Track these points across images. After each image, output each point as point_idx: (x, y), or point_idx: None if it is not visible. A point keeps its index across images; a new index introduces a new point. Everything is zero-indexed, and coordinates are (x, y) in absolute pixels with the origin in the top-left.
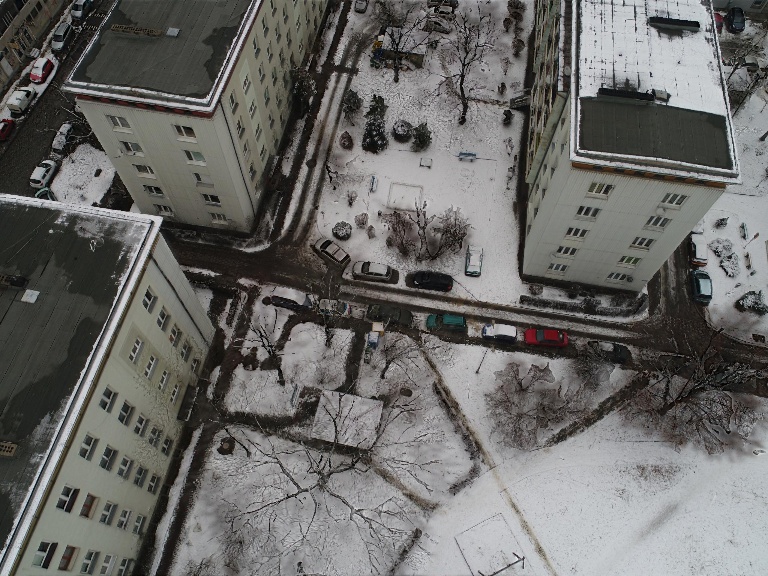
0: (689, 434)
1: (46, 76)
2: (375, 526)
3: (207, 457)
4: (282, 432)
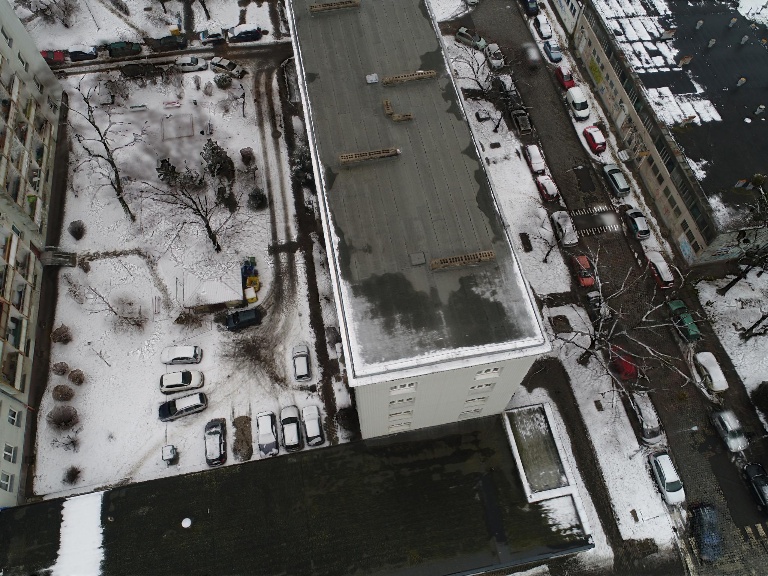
0: None
1: (587, 138)
2: None
3: None
4: None
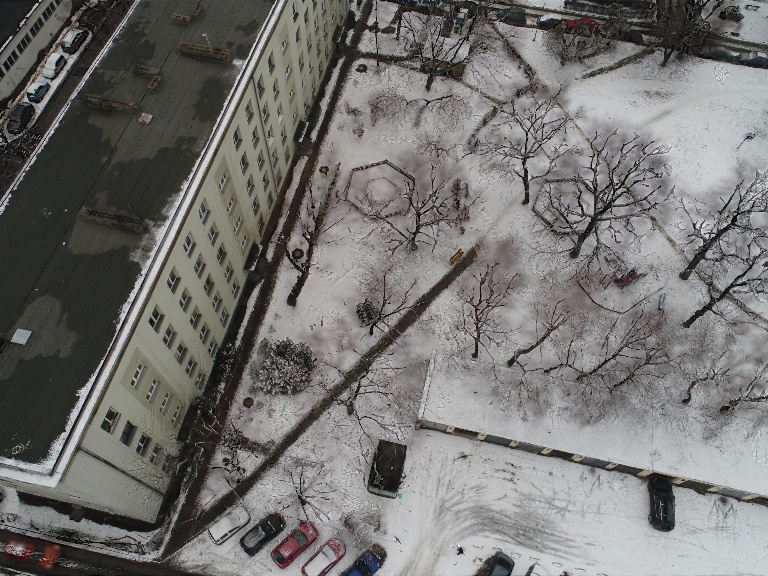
0: (681, 77)
1: None
2: None
3: (349, 73)
4: (399, 63)
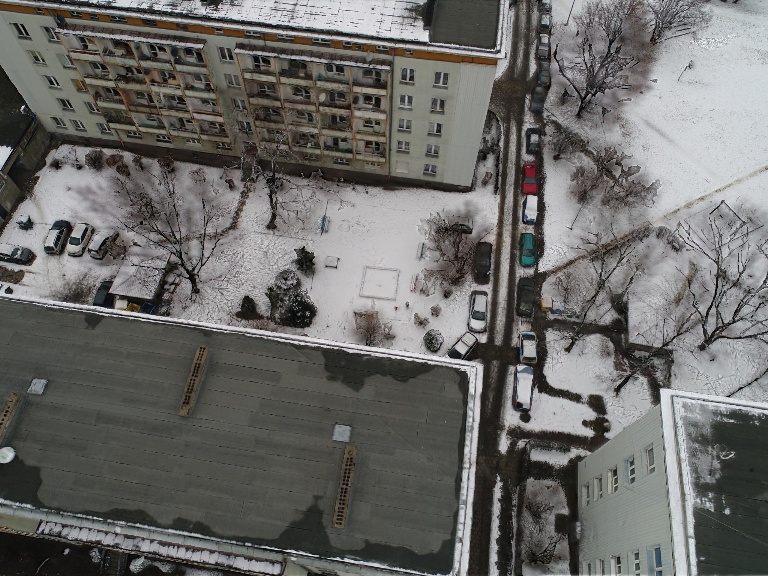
0: (591, 105)
1: None
2: (721, 306)
3: None
4: (665, 386)
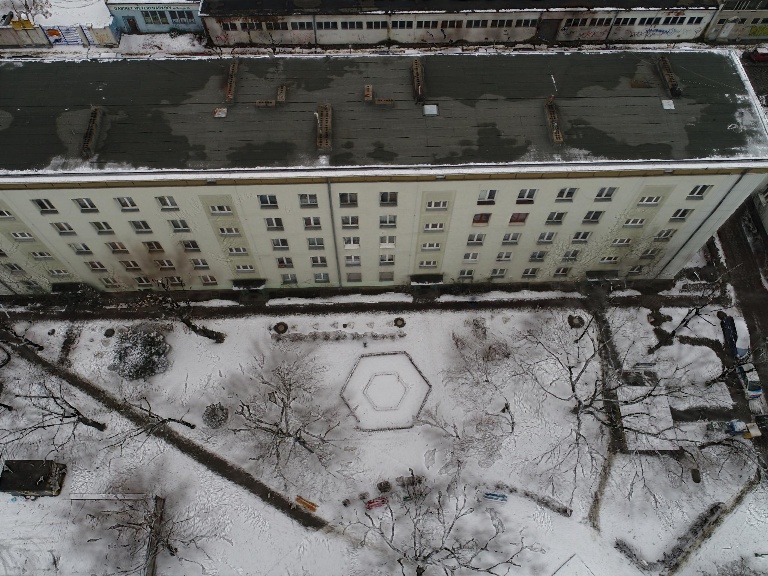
0: None
1: None
2: None
3: (561, 309)
4: (606, 364)
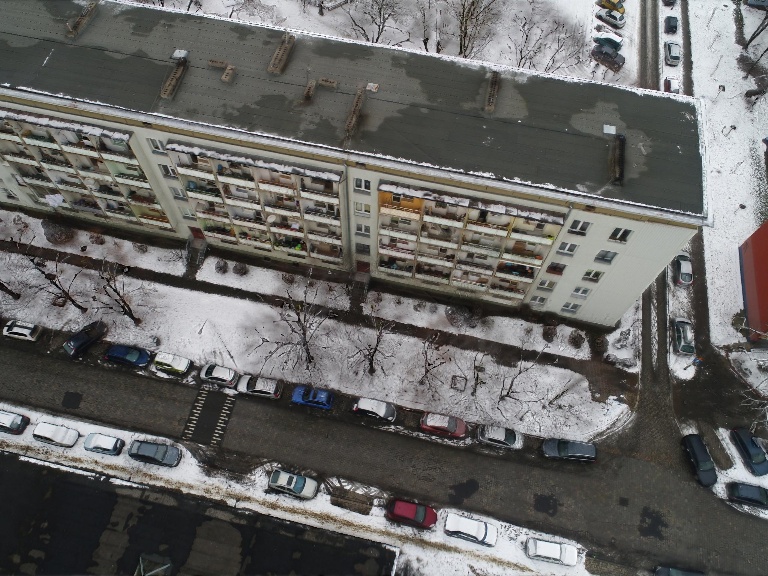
0: None
1: None
2: None
3: None
4: None
